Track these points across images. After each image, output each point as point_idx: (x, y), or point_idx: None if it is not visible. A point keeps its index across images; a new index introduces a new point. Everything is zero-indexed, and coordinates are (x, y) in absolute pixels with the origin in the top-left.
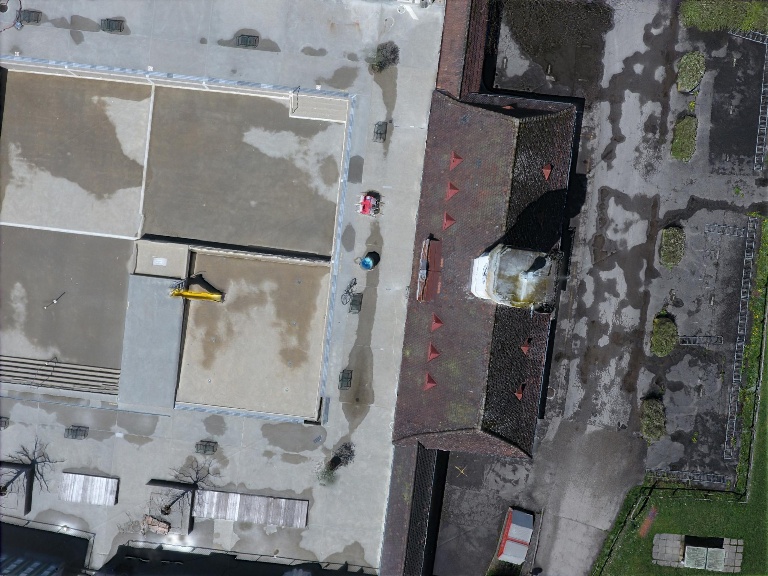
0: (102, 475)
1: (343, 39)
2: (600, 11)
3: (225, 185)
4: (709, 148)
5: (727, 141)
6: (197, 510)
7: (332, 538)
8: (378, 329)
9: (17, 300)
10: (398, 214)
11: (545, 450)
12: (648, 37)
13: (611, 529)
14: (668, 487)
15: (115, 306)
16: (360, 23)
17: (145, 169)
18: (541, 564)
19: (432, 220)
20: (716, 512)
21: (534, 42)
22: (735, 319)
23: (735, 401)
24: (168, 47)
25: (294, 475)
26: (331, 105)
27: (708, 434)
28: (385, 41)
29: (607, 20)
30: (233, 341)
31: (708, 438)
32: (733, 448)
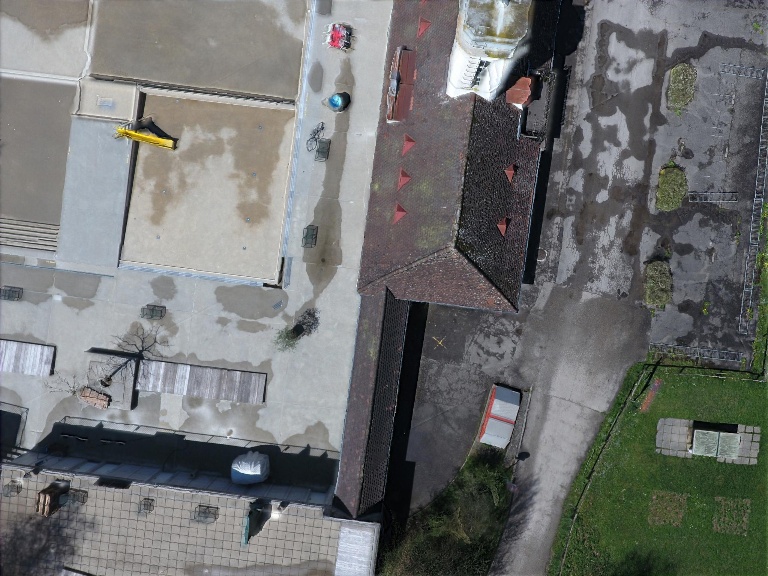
0: (37, 342)
1: None
2: None
3: (180, 20)
4: None
5: None
6: (141, 382)
7: (293, 417)
8: (347, 180)
9: None
10: (371, 49)
11: (535, 320)
12: None
13: (609, 411)
14: (674, 364)
15: (55, 154)
16: None
17: (91, 1)
18: (529, 448)
19: (405, 30)
20: (729, 394)
21: None
22: (752, 173)
23: (752, 268)
24: None
25: (251, 345)
26: None
27: (721, 305)
28: None
29: None
30: (185, 193)
31: (721, 309)
32: (749, 321)
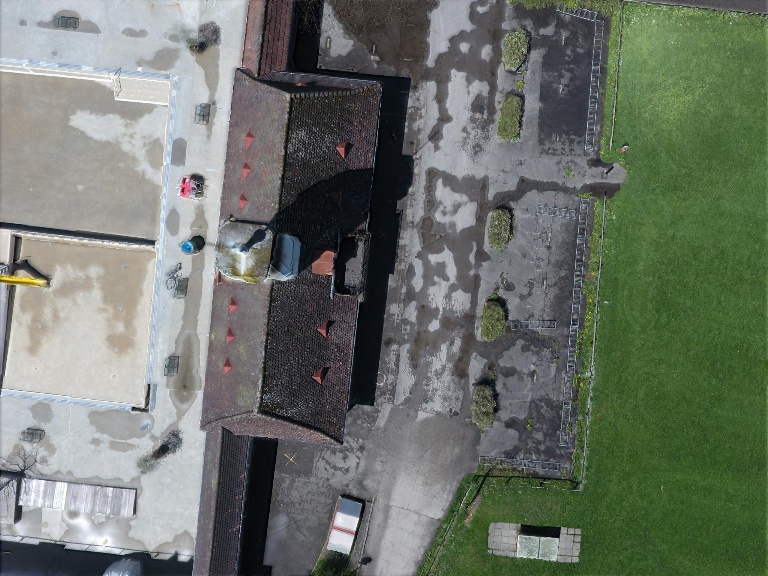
0: None
1: (164, 20)
2: None
3: (52, 169)
4: (538, 128)
5: (557, 121)
6: (24, 499)
7: (161, 527)
8: (204, 314)
9: None
10: None
11: (376, 437)
12: (474, 15)
13: (444, 518)
14: (502, 475)
15: None
16: (181, 3)
17: None
18: (371, 554)
19: (232, 201)
20: (552, 500)
21: (358, 21)
22: (568, 303)
23: (570, 387)
24: None
25: (122, 463)
26: (154, 87)
27: (543, 421)
28: (206, 22)
29: None
30: (59, 327)
31: (543, 425)
32: (569, 435)
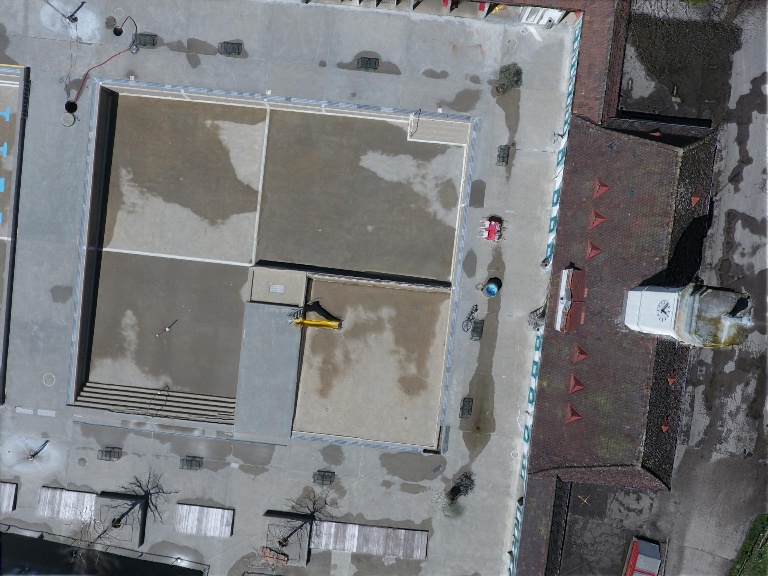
0: (217, 506)
1: (465, 61)
2: (728, 31)
3: (341, 210)
4: None
5: None
6: (315, 541)
7: (452, 569)
8: (500, 356)
9: (128, 328)
10: (521, 239)
11: None
12: None
13: (737, 558)
14: None
15: (229, 334)
16: (482, 45)
17: (260, 194)
18: None
19: (572, 248)
20: None
21: (660, 63)
22: None
23: None
24: (286, 70)
25: (413, 505)
26: (452, 128)
27: None
28: (508, 63)
29: (735, 40)
30: (351, 369)
31: None
32: None
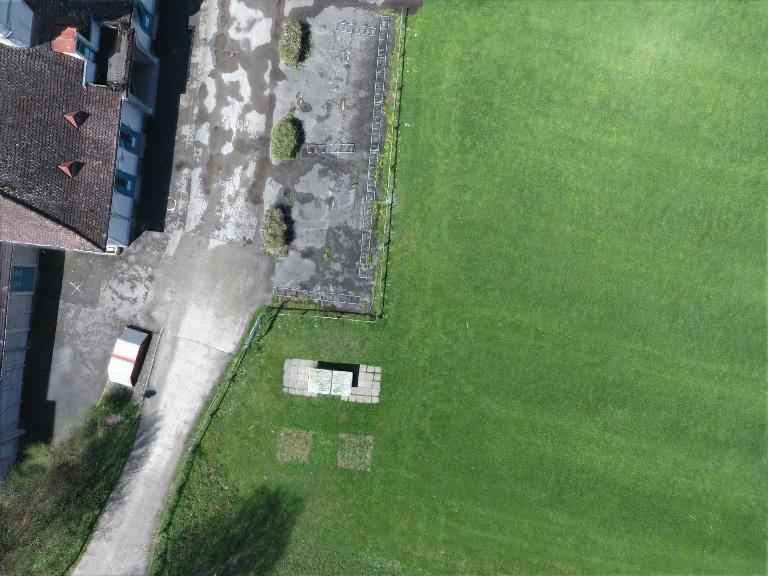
0: None
1: None
2: None
3: None
4: None
5: None
6: None
7: None
8: None
9: None
10: None
11: (165, 266)
12: None
13: (235, 352)
14: (297, 307)
15: None
16: None
17: None
18: (155, 386)
19: None
20: (350, 336)
21: None
22: (368, 126)
23: (370, 215)
24: None
25: None
26: None
27: (341, 251)
28: None
29: None
30: None
31: (341, 255)
32: (369, 266)
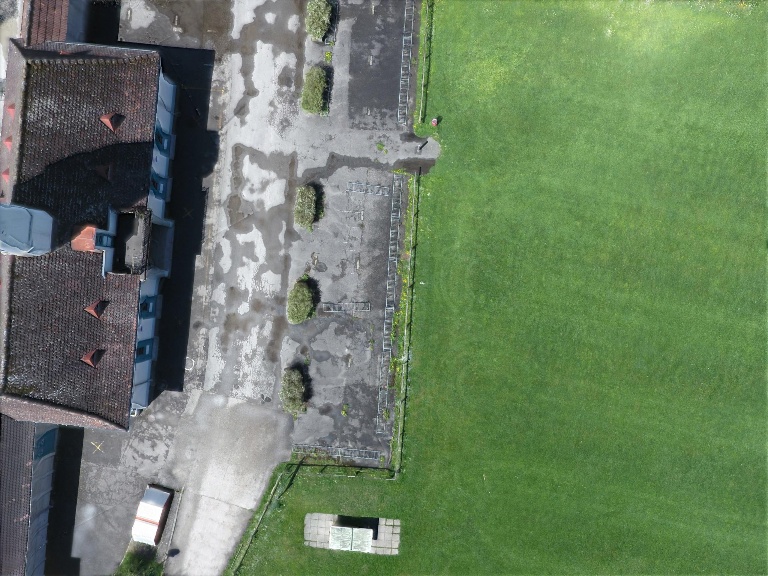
0: None
1: None
2: None
3: None
4: (348, 101)
5: (367, 94)
6: None
7: None
8: None
9: None
10: None
11: (185, 424)
12: None
13: (256, 508)
14: (316, 463)
15: None
16: None
17: None
18: (179, 545)
19: None
20: (369, 490)
21: None
22: (383, 284)
23: (386, 372)
24: None
25: None
26: None
27: (359, 407)
28: None
29: None
30: None
31: (359, 411)
32: (386, 422)
